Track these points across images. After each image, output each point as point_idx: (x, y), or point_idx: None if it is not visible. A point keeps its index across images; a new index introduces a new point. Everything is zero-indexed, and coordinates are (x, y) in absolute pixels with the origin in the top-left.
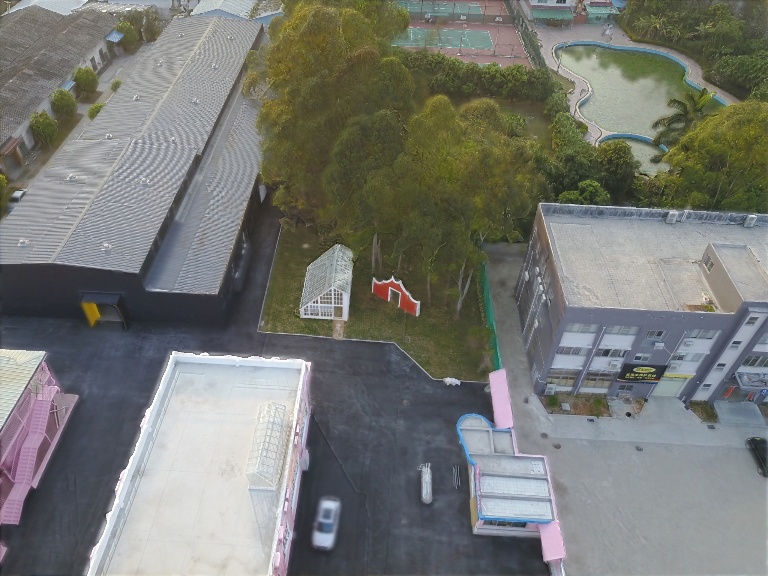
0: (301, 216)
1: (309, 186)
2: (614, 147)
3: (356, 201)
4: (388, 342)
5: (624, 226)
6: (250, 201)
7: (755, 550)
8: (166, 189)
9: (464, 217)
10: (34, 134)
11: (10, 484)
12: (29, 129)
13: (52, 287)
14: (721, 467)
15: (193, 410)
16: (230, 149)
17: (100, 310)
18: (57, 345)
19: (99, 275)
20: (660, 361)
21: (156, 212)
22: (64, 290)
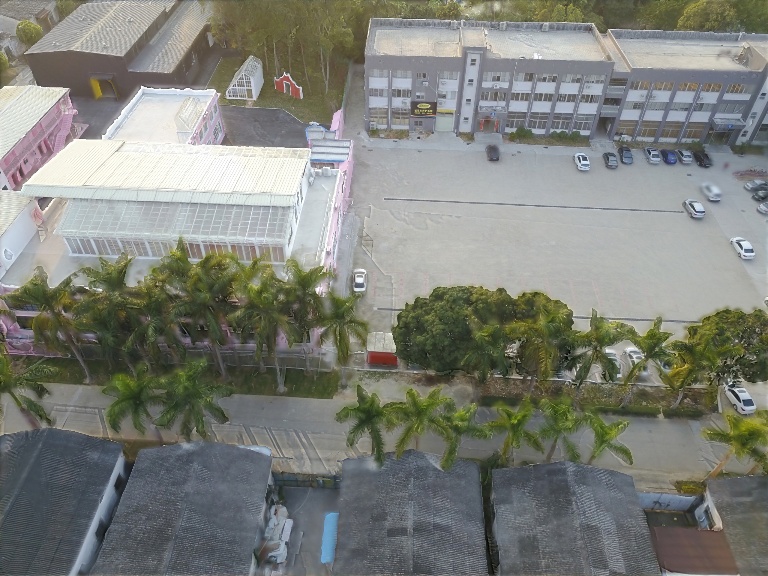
0: (229, 40)
1: (226, 6)
2: (448, 5)
3: (247, 3)
4: (279, 109)
5: (423, 30)
6: (198, 36)
7: (470, 187)
8: (143, 23)
9: (305, 5)
10: (59, 12)
11: (51, 152)
12: (56, 8)
13: (73, 71)
14: (466, 158)
15: (151, 109)
16: (189, 13)
17: (102, 90)
18: (76, 106)
19: (100, 59)
20: (432, 99)
21: (136, 33)
22: (80, 73)
